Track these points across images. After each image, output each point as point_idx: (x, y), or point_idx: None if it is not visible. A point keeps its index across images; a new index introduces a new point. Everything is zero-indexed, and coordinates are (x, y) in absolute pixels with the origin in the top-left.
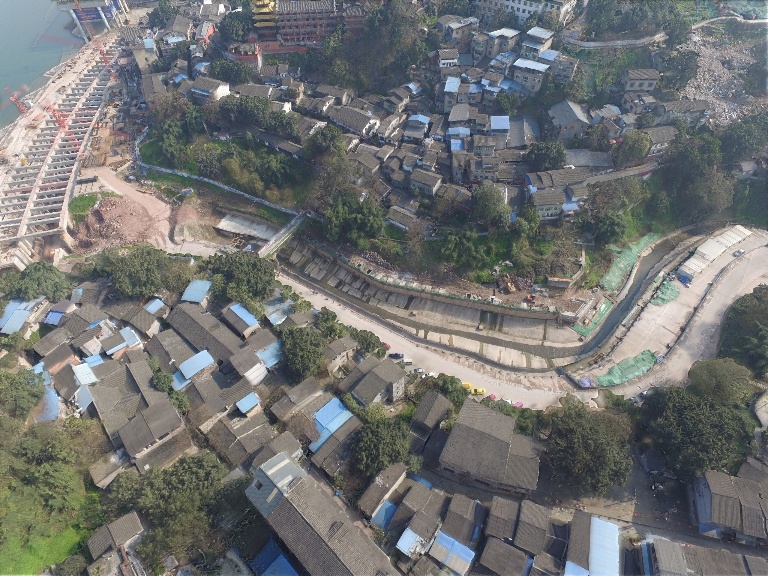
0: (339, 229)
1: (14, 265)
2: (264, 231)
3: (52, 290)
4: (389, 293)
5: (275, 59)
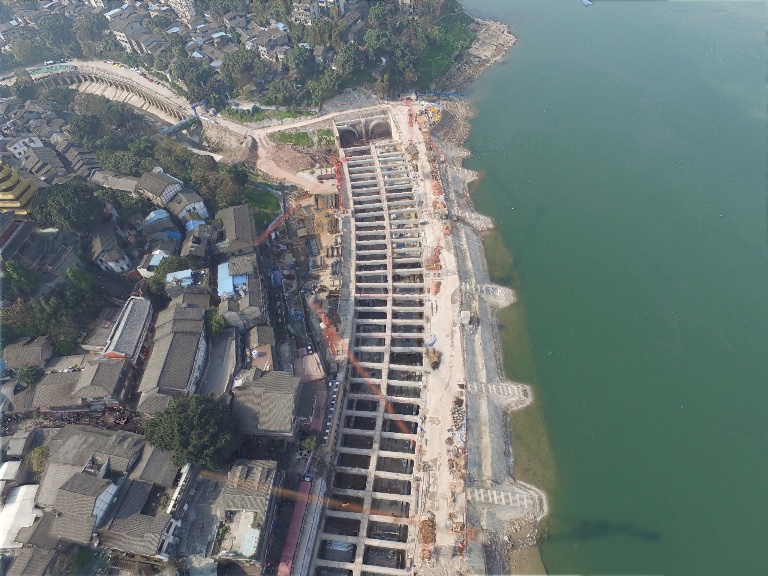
0: None
1: None
2: None
3: None
4: None
5: None
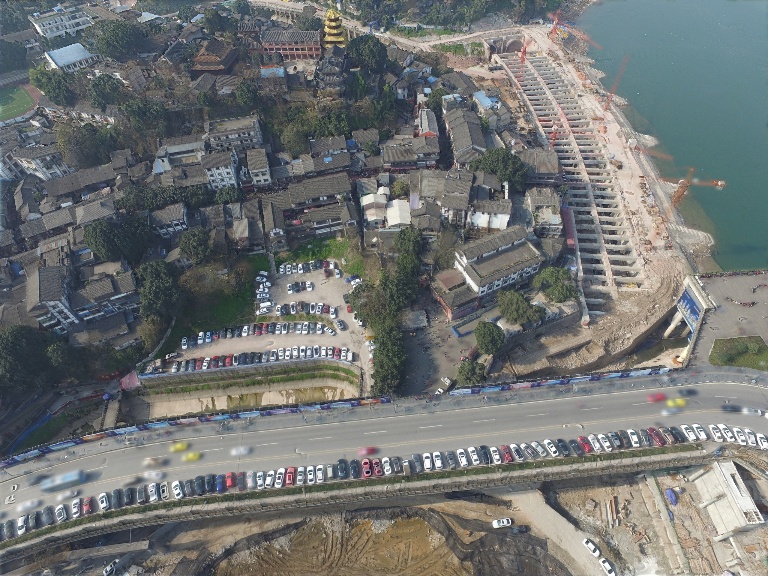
0: None
1: None
2: None
3: None
4: None
5: None
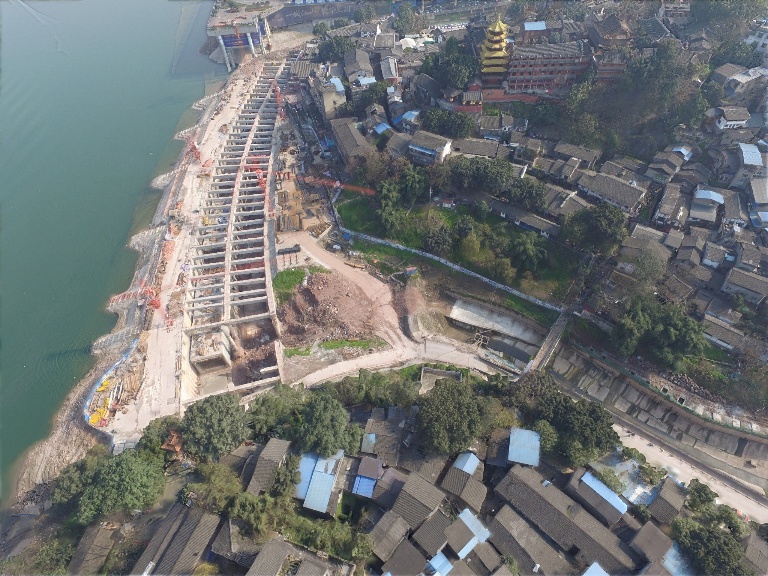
0: (637, 342)
1: (222, 355)
2: (510, 325)
3: (348, 440)
4: (709, 430)
5: (495, 109)
